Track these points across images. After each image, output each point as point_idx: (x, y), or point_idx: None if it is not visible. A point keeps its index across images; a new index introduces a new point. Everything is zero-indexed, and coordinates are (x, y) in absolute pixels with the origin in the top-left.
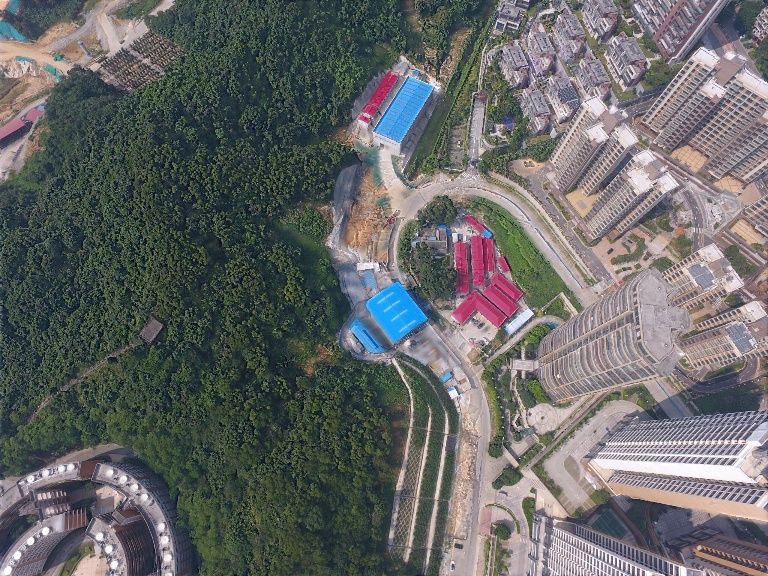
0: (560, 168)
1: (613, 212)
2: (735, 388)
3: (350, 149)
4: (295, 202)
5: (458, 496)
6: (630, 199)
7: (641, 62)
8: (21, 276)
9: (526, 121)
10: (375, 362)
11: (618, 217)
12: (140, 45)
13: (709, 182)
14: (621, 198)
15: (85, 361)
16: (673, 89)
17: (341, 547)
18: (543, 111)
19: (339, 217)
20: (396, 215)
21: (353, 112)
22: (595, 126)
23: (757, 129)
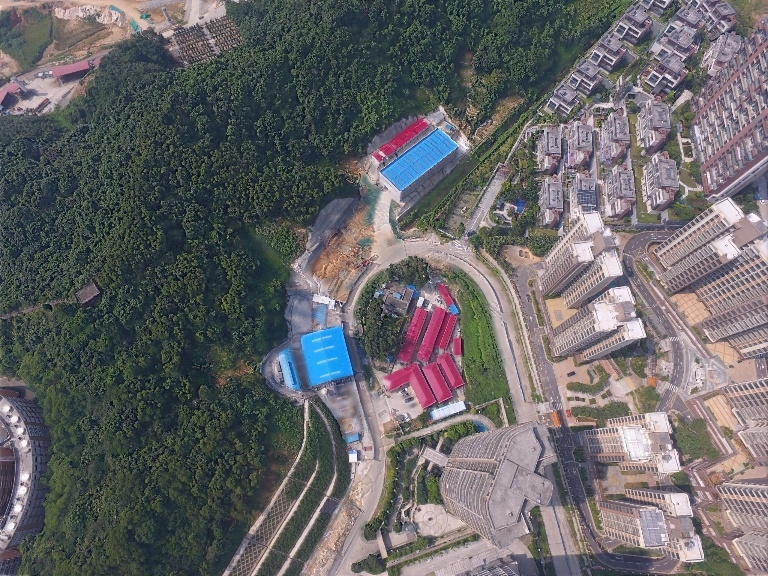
0: (546, 271)
1: (575, 337)
2: (642, 575)
3: (355, 181)
4: (275, 216)
5: (317, 562)
6: (590, 332)
7: (672, 189)
8: (13, 203)
9: (537, 210)
10: (288, 397)
11: (580, 344)
12: (214, 25)
13: (702, 341)
14: (584, 327)
15: (27, 299)
16: (689, 230)
17: (164, 568)
18: (556, 206)
19: (314, 244)
20: (373, 260)
21: (370, 147)
22: (584, 243)
23: (759, 307)
